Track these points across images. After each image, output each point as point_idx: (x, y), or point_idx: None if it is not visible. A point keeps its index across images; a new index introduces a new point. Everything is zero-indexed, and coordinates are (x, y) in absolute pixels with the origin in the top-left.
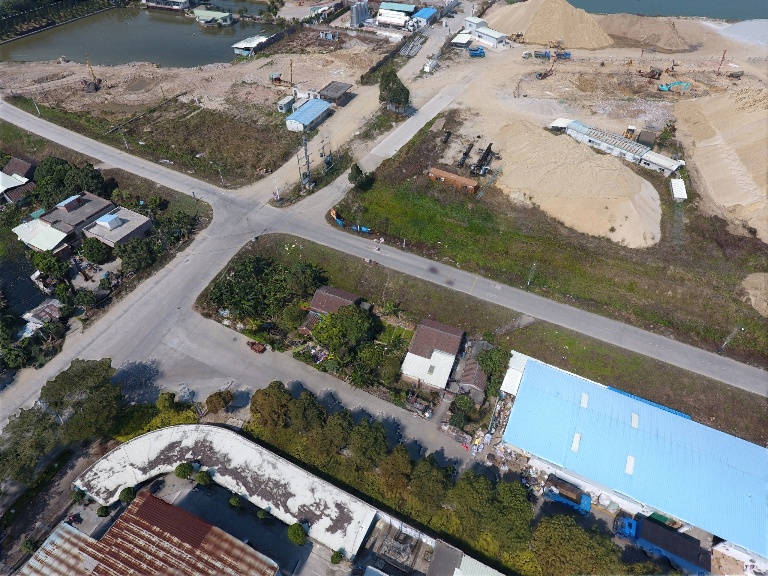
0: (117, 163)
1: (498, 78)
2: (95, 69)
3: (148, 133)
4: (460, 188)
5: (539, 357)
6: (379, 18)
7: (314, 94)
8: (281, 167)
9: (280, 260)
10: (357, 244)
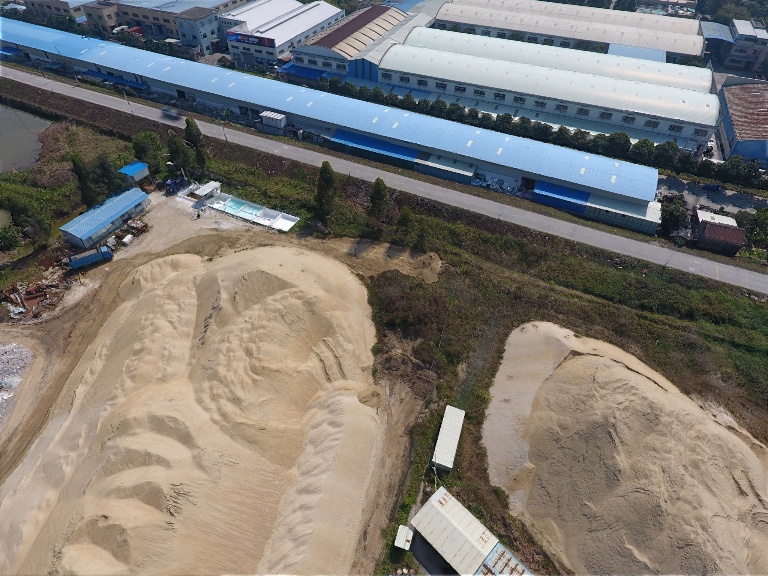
0: None
1: None
2: None
3: None
4: None
5: (632, 233)
6: None
7: None
8: None
9: None
10: None
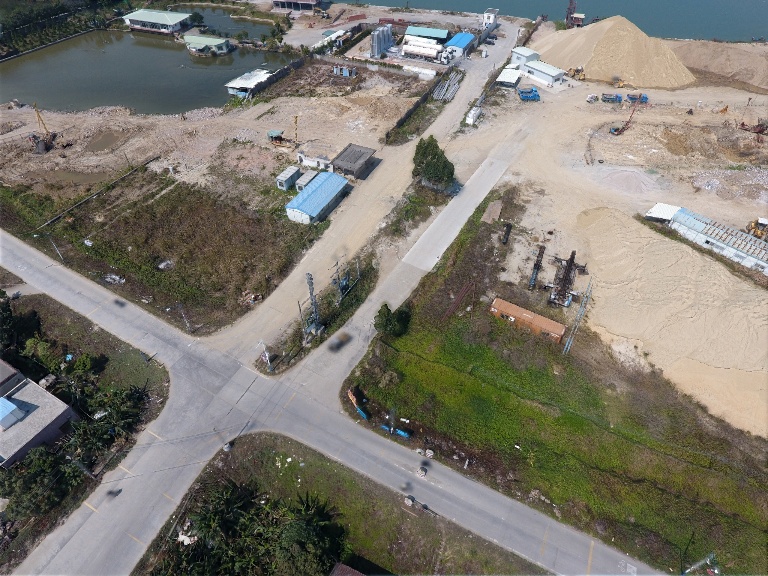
0: (44, 284)
1: (561, 133)
2: (52, 118)
3: (99, 226)
4: (538, 334)
5: None
6: (405, 47)
7: (325, 161)
8: (277, 289)
9: (267, 485)
10: (390, 459)
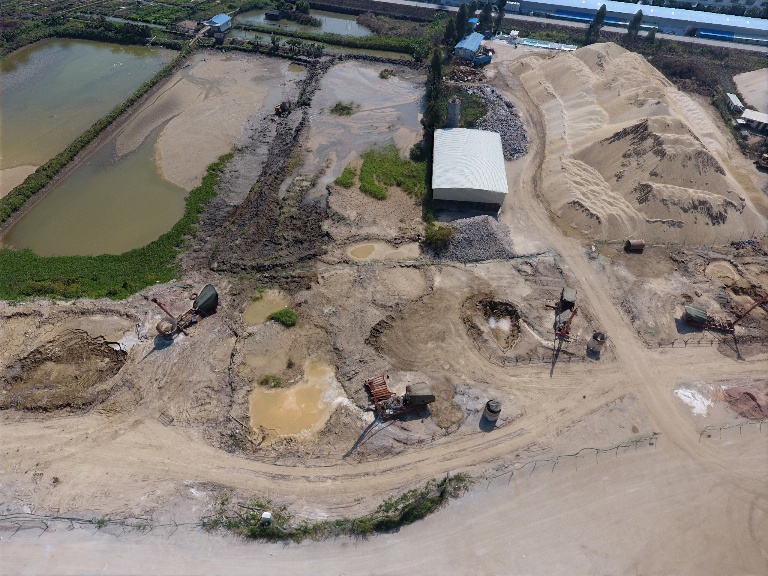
0: None
1: None
2: None
3: None
4: None
5: None
6: None
7: None
8: None
9: None
10: None
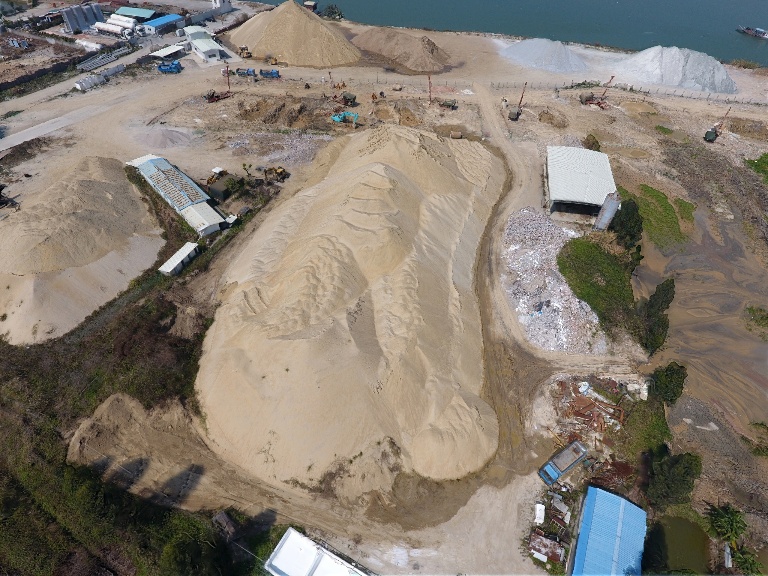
0: None
1: (160, 100)
2: None
3: None
4: None
5: None
6: (97, 24)
7: None
8: None
9: None
10: None
